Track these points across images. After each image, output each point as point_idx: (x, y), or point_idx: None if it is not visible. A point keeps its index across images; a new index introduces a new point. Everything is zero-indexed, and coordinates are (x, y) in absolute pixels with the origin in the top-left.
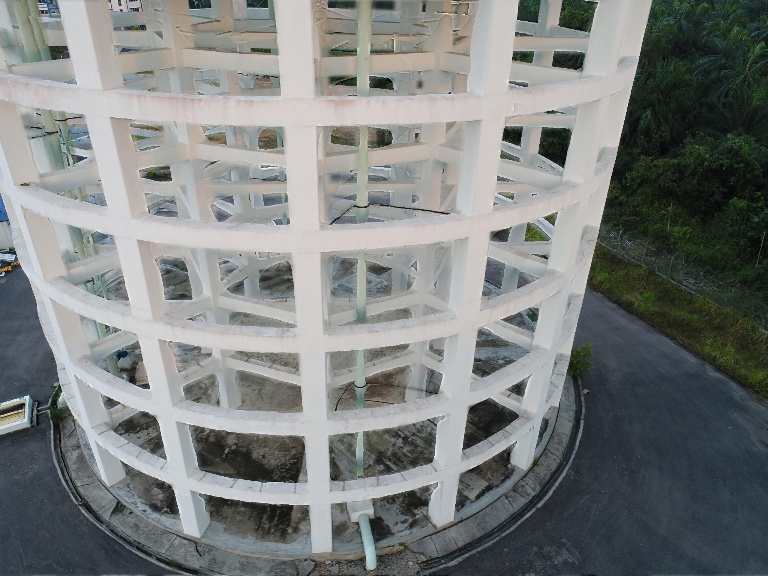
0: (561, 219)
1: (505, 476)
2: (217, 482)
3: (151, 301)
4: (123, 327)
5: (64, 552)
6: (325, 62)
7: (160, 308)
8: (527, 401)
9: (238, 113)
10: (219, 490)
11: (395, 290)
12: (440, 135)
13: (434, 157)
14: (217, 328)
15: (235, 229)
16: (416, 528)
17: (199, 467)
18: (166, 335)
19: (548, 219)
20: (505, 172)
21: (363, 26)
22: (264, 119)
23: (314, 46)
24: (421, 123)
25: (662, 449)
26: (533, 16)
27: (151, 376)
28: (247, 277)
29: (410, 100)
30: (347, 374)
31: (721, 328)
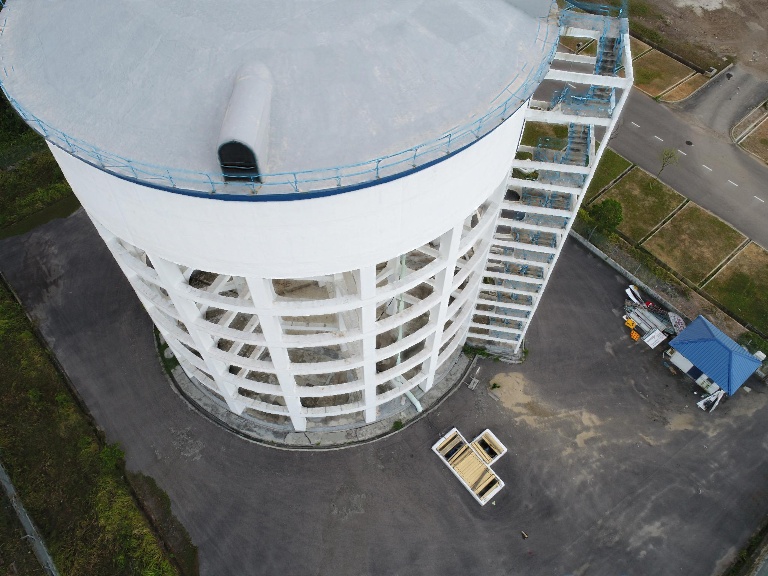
0: None
1: None
2: None
3: None
4: None
5: None
6: None
7: None
8: None
9: None
10: None
11: None
12: None
13: None
14: None
15: None
16: None
17: None
18: None
19: None
20: None
21: None
22: None
23: None
24: None
25: None
26: None
27: None
28: None
29: None
30: None
31: (3, 416)
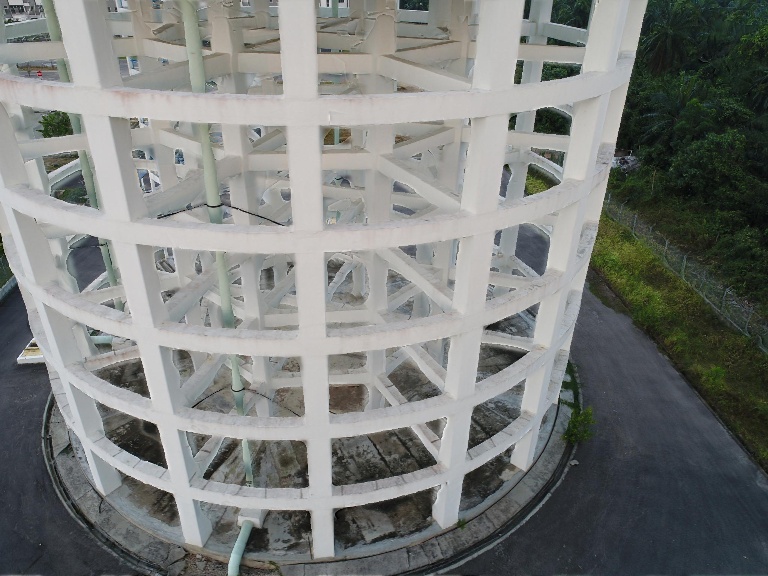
0: (460, 253)
1: (417, 528)
2: (106, 448)
3: (32, 266)
4: (25, 286)
5: (9, 474)
6: (242, 58)
7: (47, 274)
8: (442, 452)
9: (44, 97)
10: (105, 456)
11: (416, 306)
12: (384, 145)
13: (376, 168)
14: (77, 302)
15: (66, 209)
16: (293, 551)
17: (146, 432)
18: (46, 300)
19: (653, 261)
20: (423, 192)
21: (186, 19)
22: (65, 105)
23: (226, 41)
24: (412, 132)
25: (631, 555)
26: (739, 29)
27: (47, 335)
28: (273, 267)
29: (196, 97)
30: (288, 378)
31: None
